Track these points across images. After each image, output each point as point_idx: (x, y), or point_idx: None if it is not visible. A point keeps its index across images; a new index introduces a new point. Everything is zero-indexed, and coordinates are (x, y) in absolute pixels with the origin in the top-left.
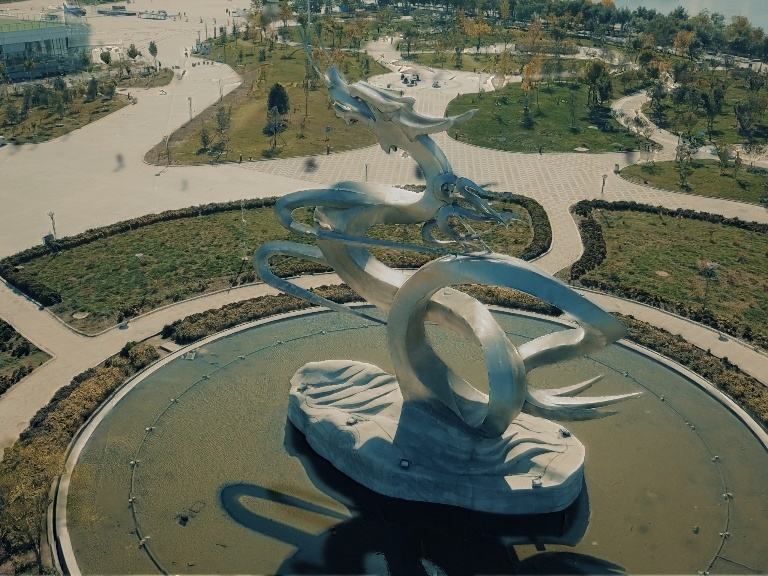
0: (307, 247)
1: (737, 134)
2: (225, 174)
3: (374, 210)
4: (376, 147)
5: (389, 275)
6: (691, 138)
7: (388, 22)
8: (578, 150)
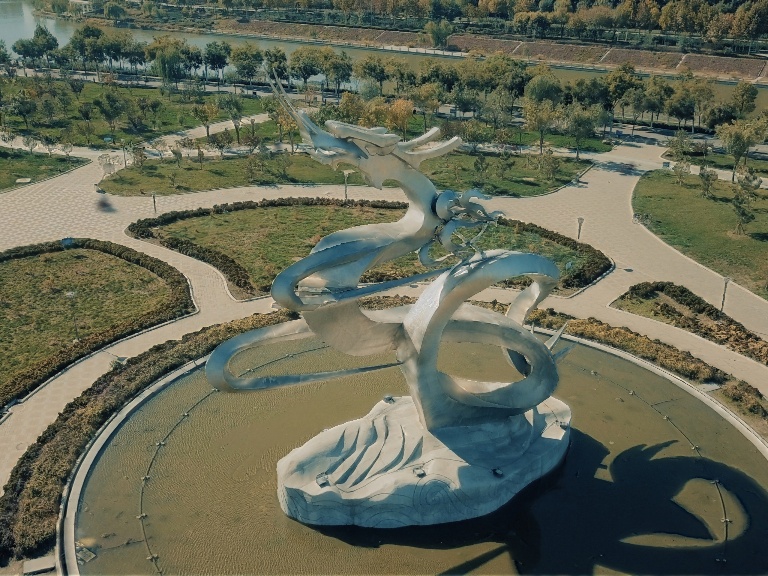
0: (278, 327)
1: (126, 134)
2: None
3: (382, 252)
4: None
5: (379, 316)
6: (131, 143)
7: None
8: (23, 182)
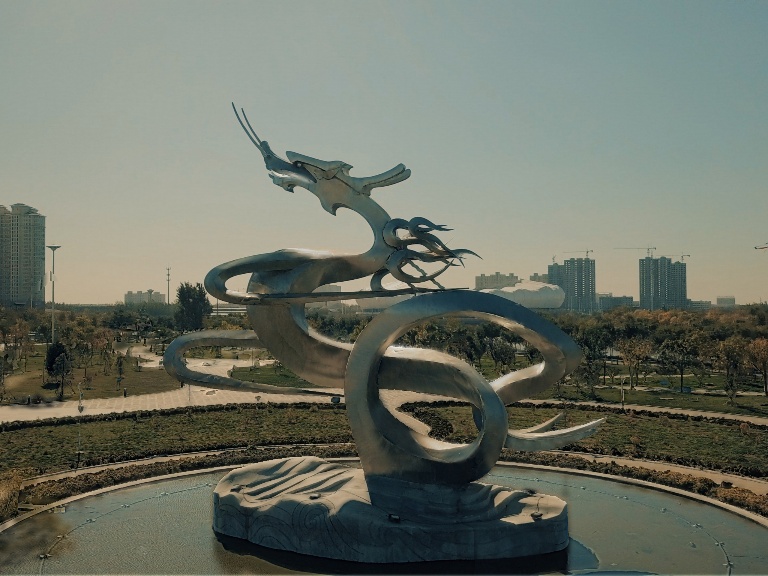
0: (232, 332)
1: None
2: (15, 410)
3: (320, 266)
4: (174, 392)
5: (332, 342)
6: (473, 365)
7: (147, 317)
8: None
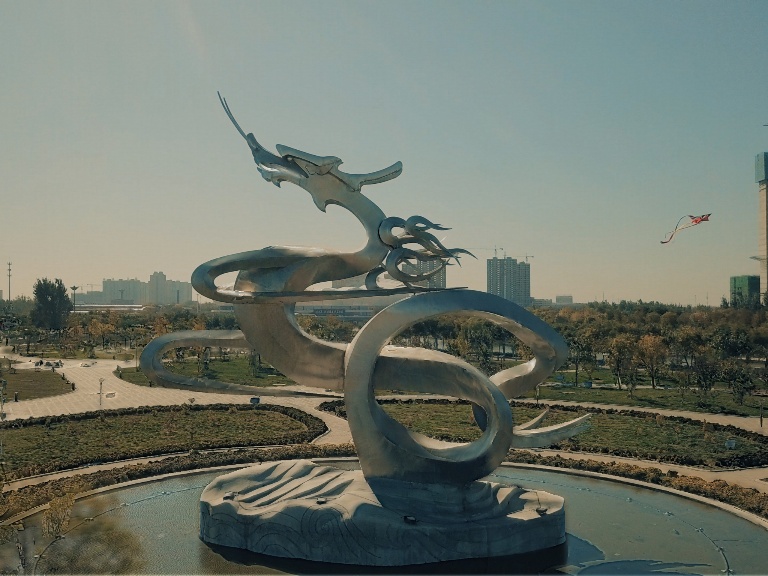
0: (216, 332)
1: None
2: None
3: (315, 264)
4: (69, 395)
5: (324, 342)
6: None
7: (13, 315)
8: (277, 385)
